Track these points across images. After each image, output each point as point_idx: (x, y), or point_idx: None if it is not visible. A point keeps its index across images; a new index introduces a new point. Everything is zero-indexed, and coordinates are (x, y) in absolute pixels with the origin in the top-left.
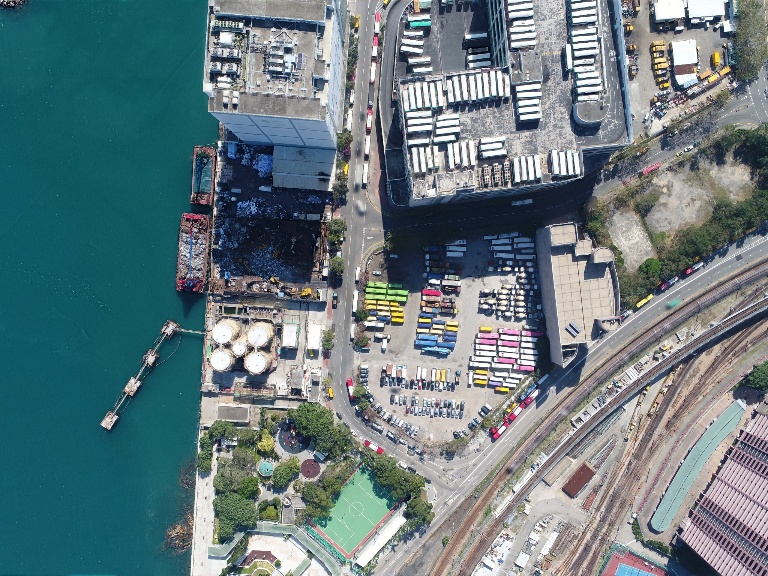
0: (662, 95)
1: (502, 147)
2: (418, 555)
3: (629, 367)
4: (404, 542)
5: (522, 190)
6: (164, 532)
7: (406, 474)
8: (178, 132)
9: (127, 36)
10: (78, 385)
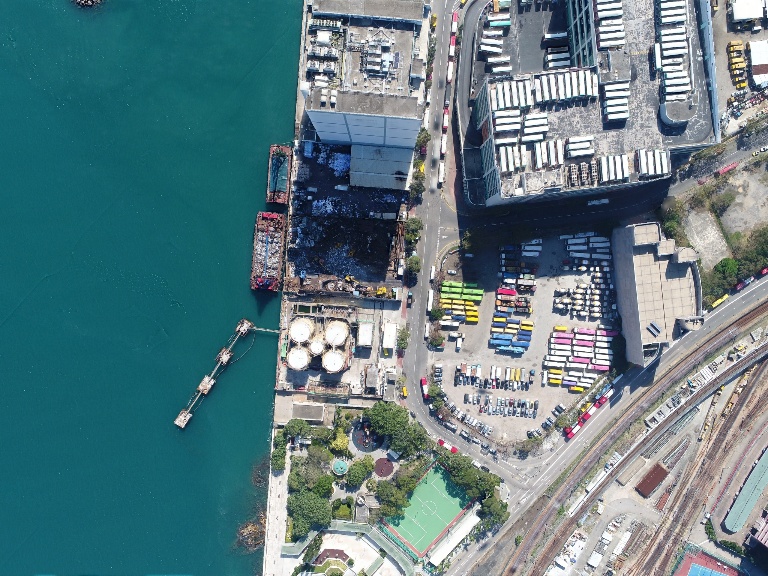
0: (739, 95)
1: (589, 146)
2: (490, 554)
3: (703, 367)
4: (477, 541)
5: (603, 189)
6: (236, 530)
7: (481, 473)
8: (254, 131)
9: (204, 35)
10: (154, 383)
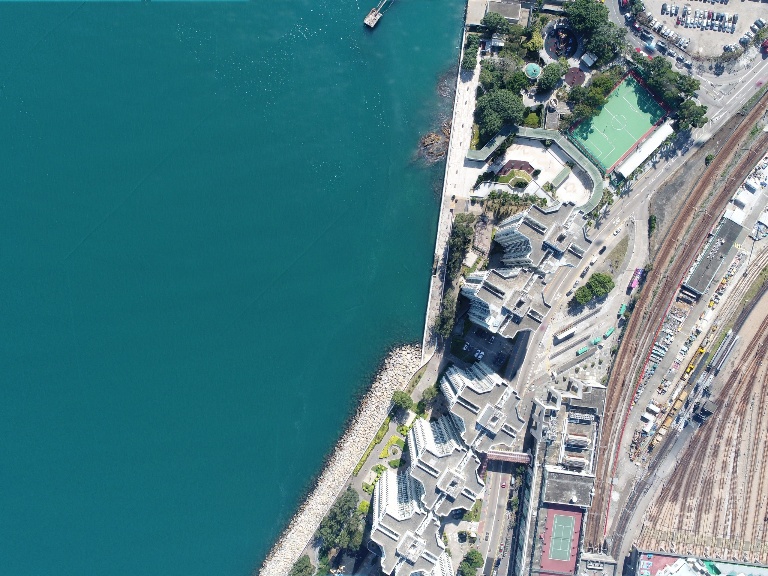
0: None
1: None
2: (679, 174)
3: None
4: (665, 159)
5: None
6: (417, 141)
7: None
8: None
9: None
10: None
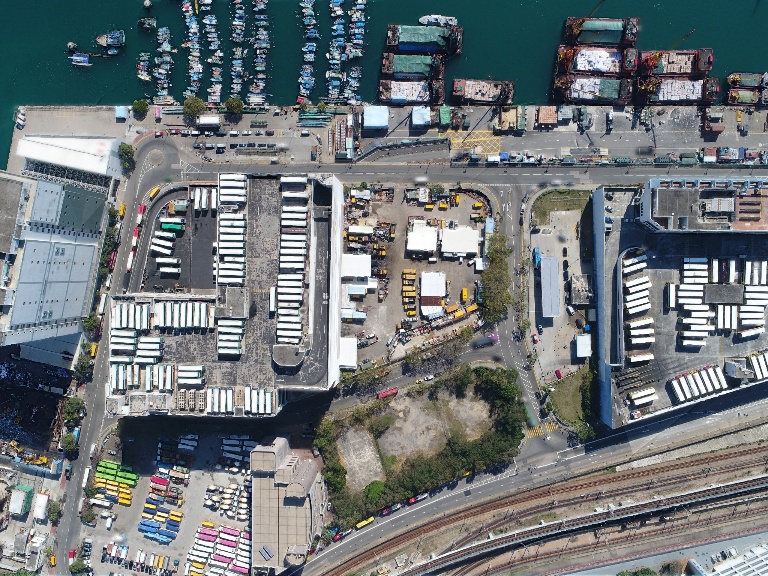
0: (408, 322)
1: (203, 374)
2: None
3: None
4: None
5: None
6: None
7: None
8: None
9: None
10: None
